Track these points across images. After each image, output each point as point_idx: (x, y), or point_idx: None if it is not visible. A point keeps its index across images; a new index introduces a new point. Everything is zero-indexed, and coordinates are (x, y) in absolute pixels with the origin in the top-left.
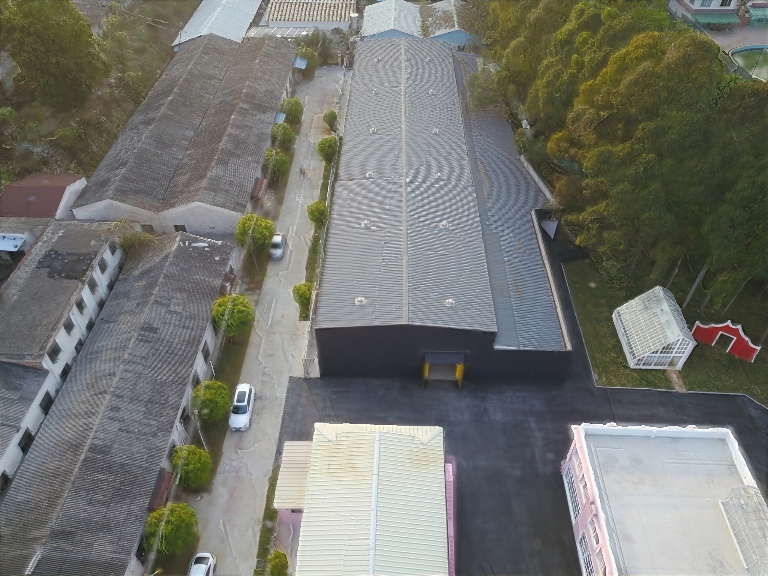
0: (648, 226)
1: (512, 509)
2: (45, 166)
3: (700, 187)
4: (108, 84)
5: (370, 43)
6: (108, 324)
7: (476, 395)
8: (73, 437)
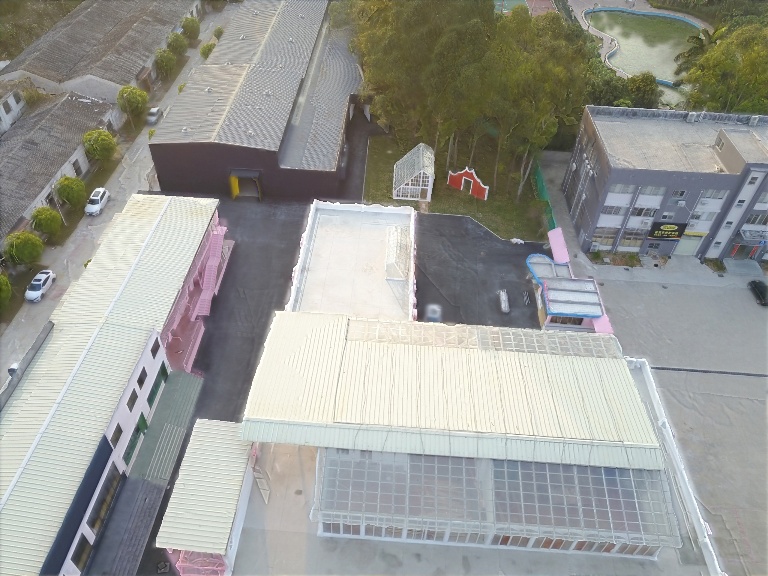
0: (397, 87)
1: (270, 263)
2: None
3: (415, 50)
4: (43, 1)
5: None
6: (4, 142)
7: (271, 205)
8: None
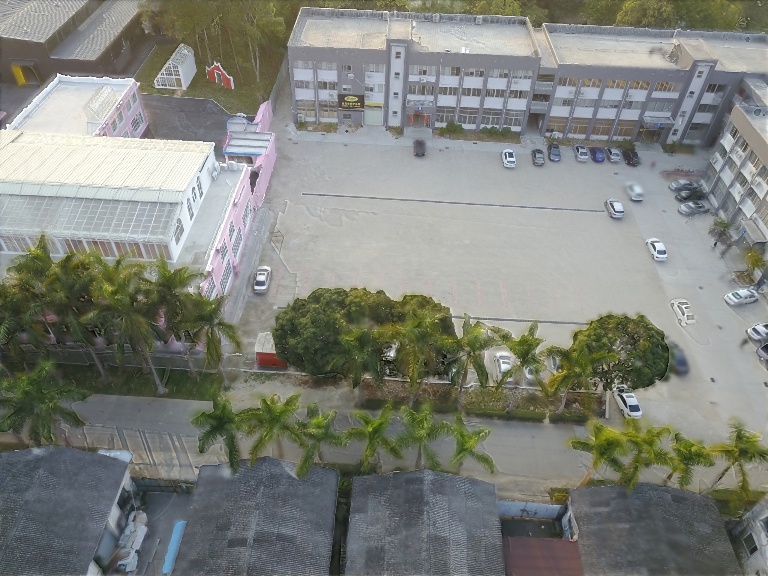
0: None
1: None
2: None
3: None
4: None
5: None
6: None
7: None
8: None
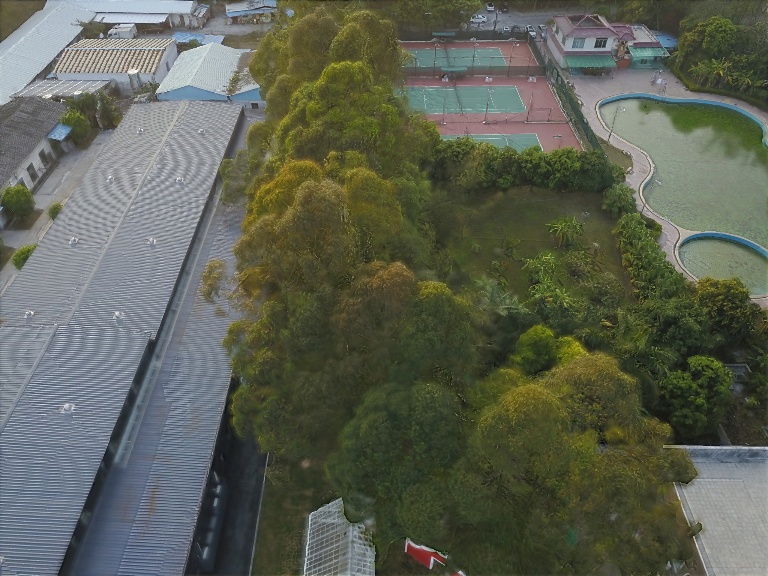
0: None
1: None
2: None
3: (308, 418)
4: None
5: (144, 107)
6: None
7: None
8: None
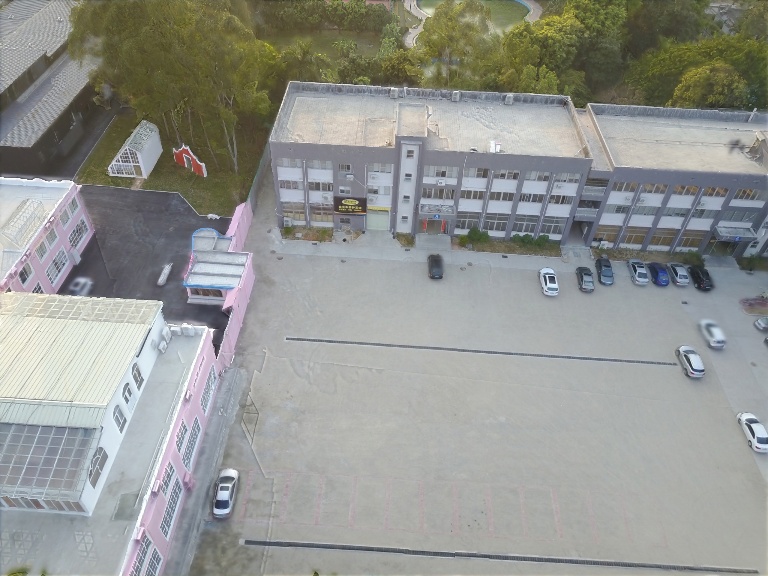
0: None
1: None
2: None
3: (91, 25)
4: None
5: None
6: None
7: None
8: None
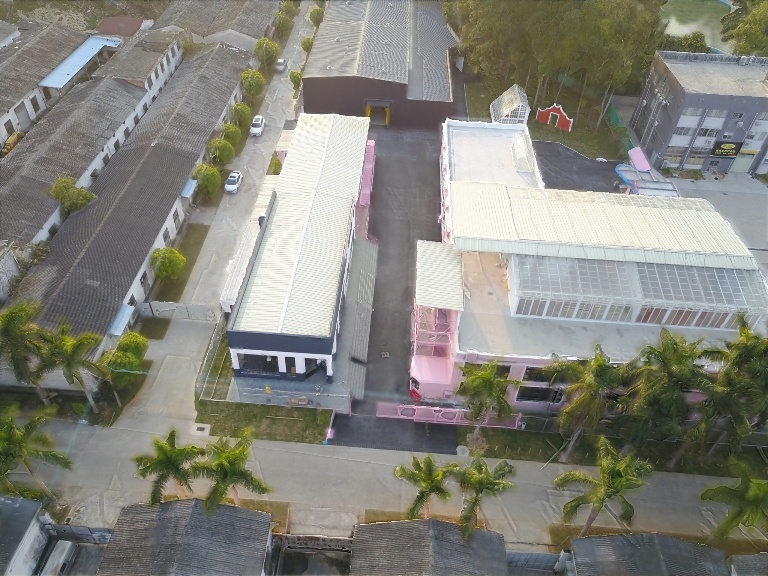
0: (502, 34)
1: (408, 171)
2: (124, 15)
3: (524, 1)
4: None
5: None
6: (179, 78)
7: (397, 131)
8: (166, 112)
